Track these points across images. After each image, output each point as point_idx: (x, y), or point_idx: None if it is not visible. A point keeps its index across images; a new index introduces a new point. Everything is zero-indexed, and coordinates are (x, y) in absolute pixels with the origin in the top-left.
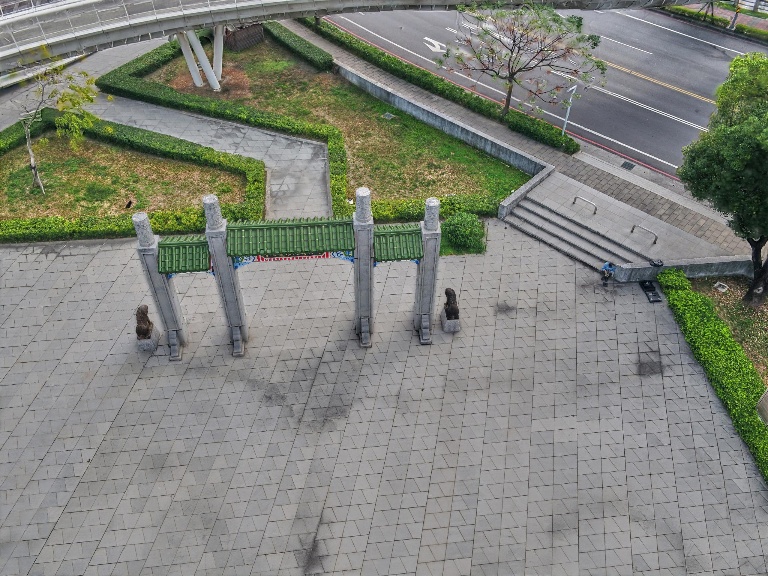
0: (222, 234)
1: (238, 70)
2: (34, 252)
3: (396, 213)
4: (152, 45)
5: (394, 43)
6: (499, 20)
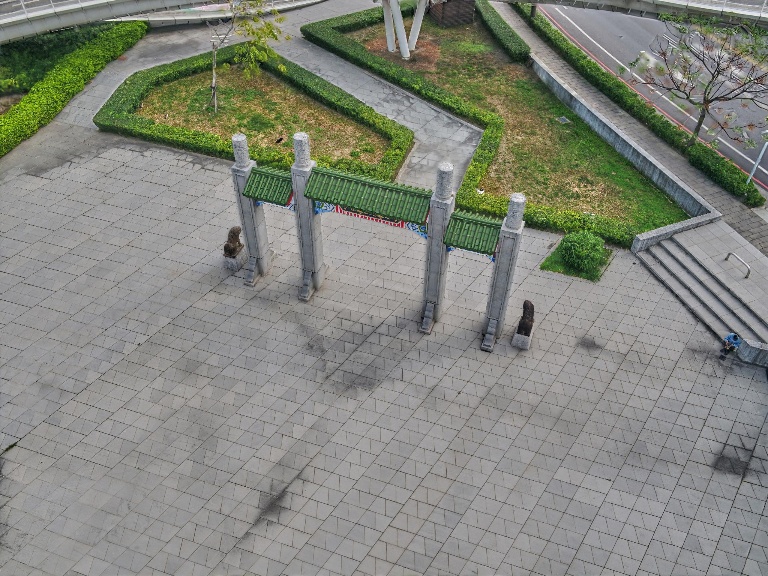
0: (305, 174)
1: (434, 44)
2: (186, 159)
3: None
4: (368, 7)
5: (605, 50)
6: (707, 37)
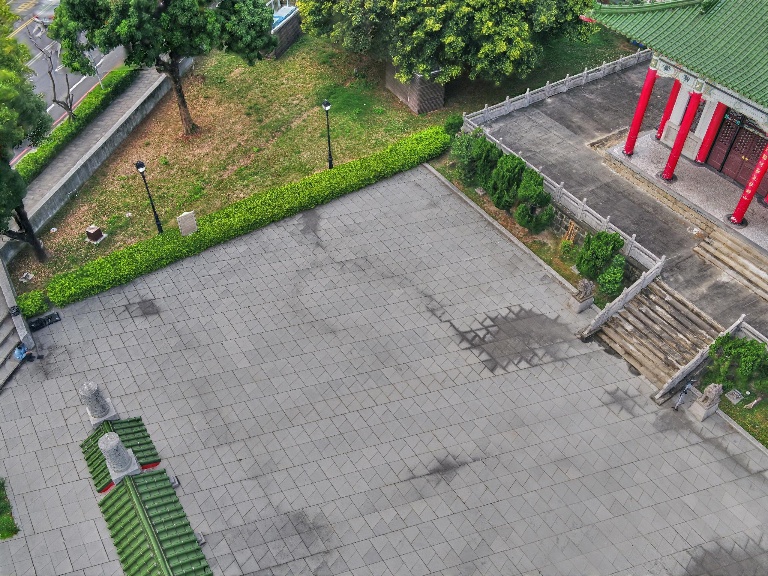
0: None
1: None
2: None
3: None
4: None
5: None
6: None
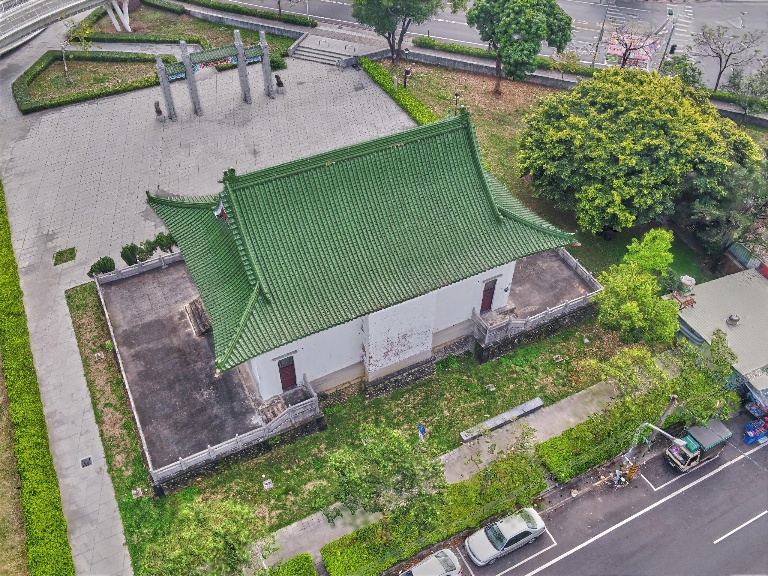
0: (188, 56)
1: (136, 21)
2: (85, 105)
3: None
4: (79, 17)
5: None
6: None
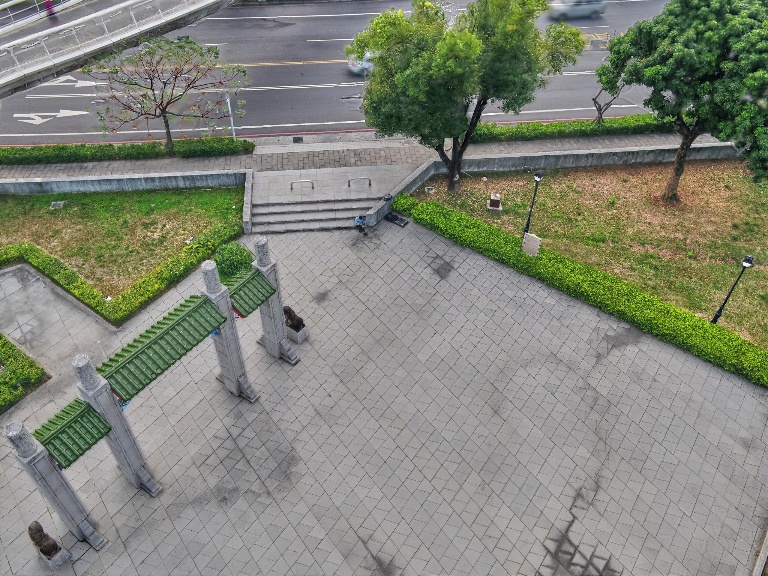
0: (106, 386)
1: None
2: None
3: (164, 282)
4: None
5: None
6: (127, 66)
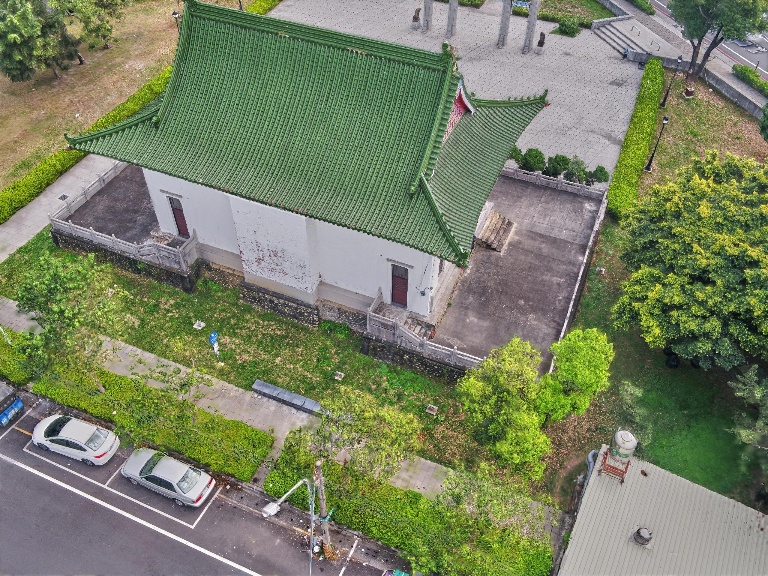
0: None
1: None
2: None
3: (542, 15)
4: None
5: None
6: None
